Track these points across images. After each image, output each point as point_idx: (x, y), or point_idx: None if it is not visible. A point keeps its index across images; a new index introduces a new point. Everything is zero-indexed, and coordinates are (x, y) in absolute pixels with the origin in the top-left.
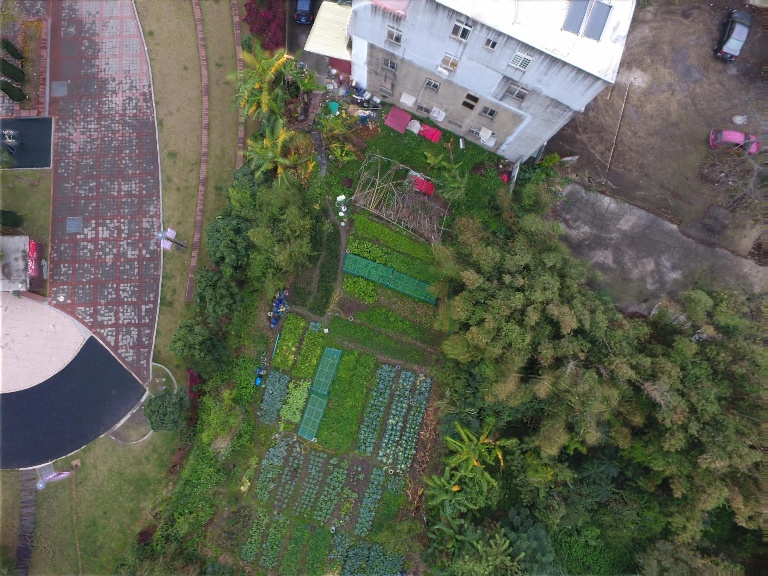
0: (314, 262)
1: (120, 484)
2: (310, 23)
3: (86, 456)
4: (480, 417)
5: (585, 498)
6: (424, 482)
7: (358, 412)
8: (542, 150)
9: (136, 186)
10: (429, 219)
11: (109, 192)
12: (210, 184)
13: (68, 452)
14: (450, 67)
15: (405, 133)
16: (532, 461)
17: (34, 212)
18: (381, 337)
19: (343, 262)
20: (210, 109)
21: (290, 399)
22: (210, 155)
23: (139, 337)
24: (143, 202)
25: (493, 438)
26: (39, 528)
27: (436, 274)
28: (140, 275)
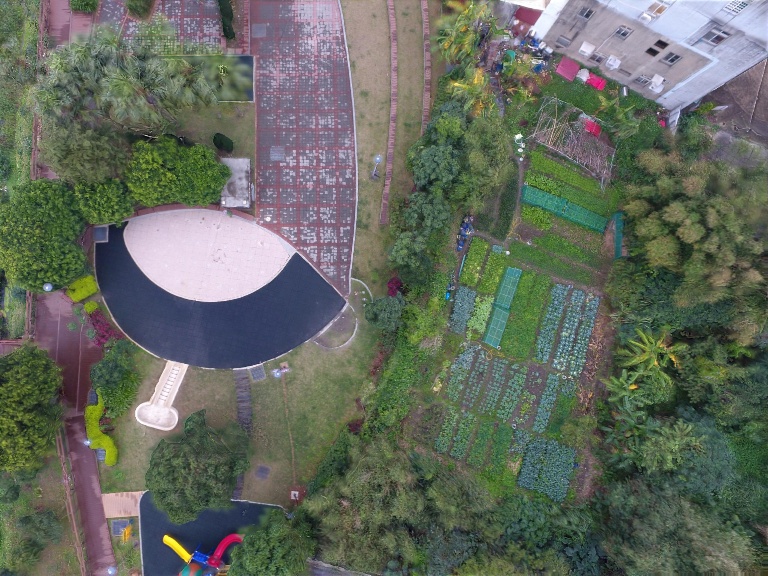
0: (496, 192)
1: (326, 383)
2: None
3: (293, 359)
4: (652, 327)
5: (751, 393)
6: (593, 387)
7: (536, 325)
8: (701, 98)
9: (332, 121)
10: (600, 156)
11: (308, 125)
12: (400, 121)
13: (277, 355)
14: (653, 14)
15: (574, 81)
16: (704, 362)
17: (241, 141)
18: (555, 260)
19: (522, 193)
20: (399, 53)
21: (478, 311)
22: (399, 95)
23: (339, 255)
24: (339, 135)
25: (667, 344)
26: (255, 420)
27: (604, 206)
28: (338, 200)
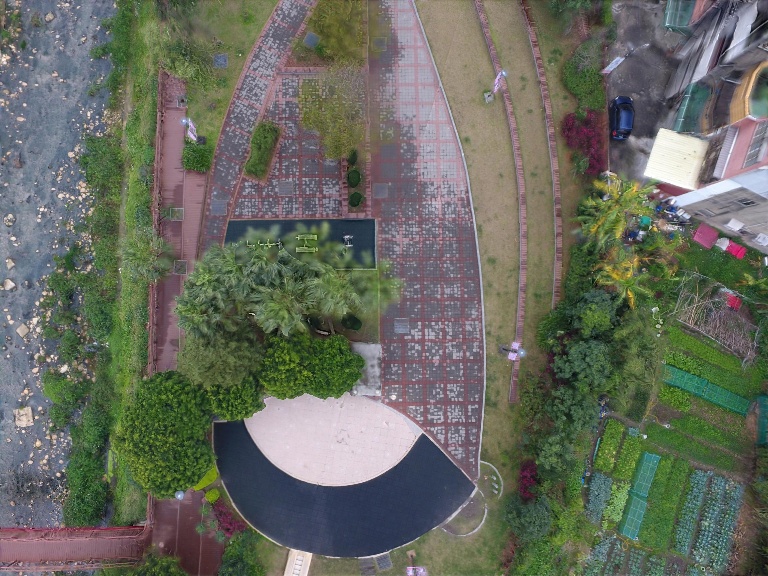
0: None
1: (456, 575)
2: (626, 139)
3: (421, 547)
4: None
5: None
6: None
7: (674, 513)
8: None
9: (458, 290)
10: (743, 335)
11: (433, 295)
12: (530, 291)
13: (403, 543)
14: None
15: (713, 249)
16: None
17: None
18: (694, 443)
19: (659, 372)
20: (528, 218)
21: (615, 501)
22: (529, 263)
23: (467, 436)
24: (465, 305)
25: None
26: None
27: (745, 386)
28: (465, 376)
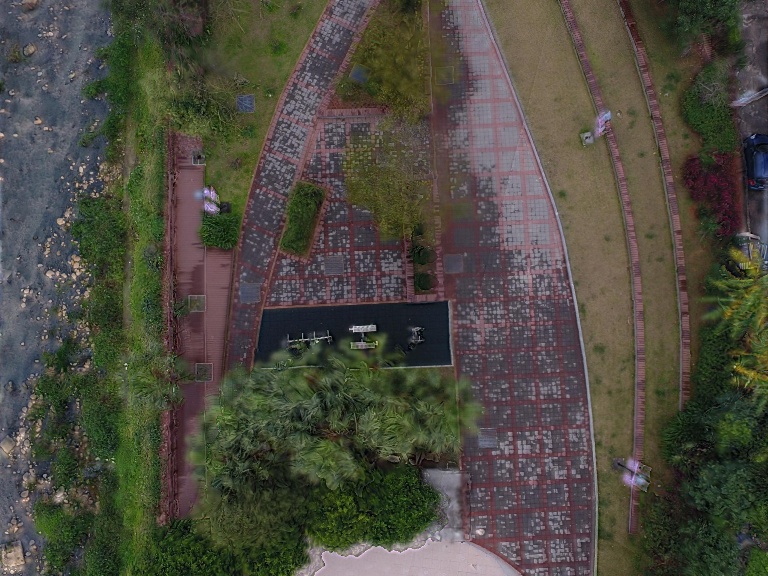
0: None
1: None
2: (767, 189)
3: None
4: None
5: None
6: None
7: None
8: None
9: (557, 388)
10: None
11: (526, 396)
12: (650, 388)
13: None
14: None
15: None
16: None
17: None
18: None
19: None
20: (644, 293)
21: None
22: (647, 351)
23: None
24: (568, 409)
25: None
26: None
27: None
28: (572, 501)
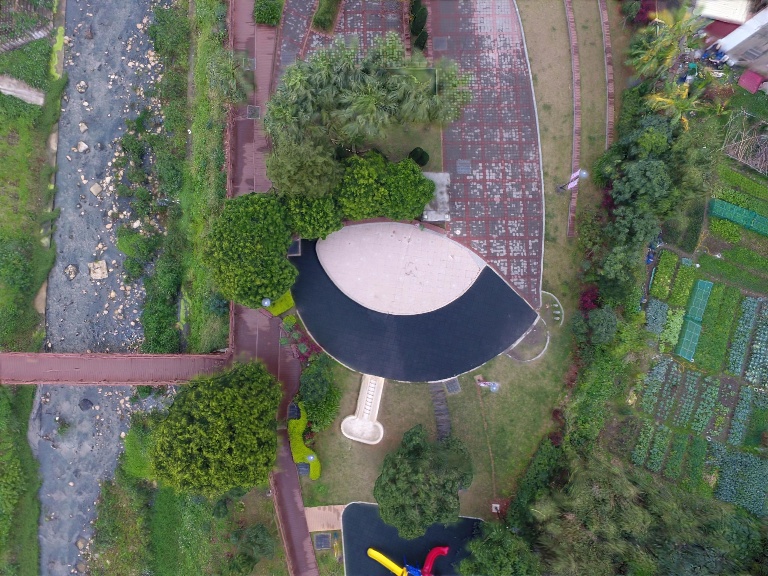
0: None
1: (522, 396)
2: None
3: (488, 372)
4: None
5: None
6: None
7: (727, 337)
8: None
9: (516, 134)
10: None
11: (492, 138)
12: (584, 134)
13: (471, 368)
14: None
15: (756, 94)
16: None
17: (428, 154)
18: (743, 273)
19: (709, 206)
20: (581, 66)
21: (671, 324)
22: (583, 108)
23: (529, 268)
24: (523, 148)
25: None
26: (454, 433)
27: None
28: (525, 213)
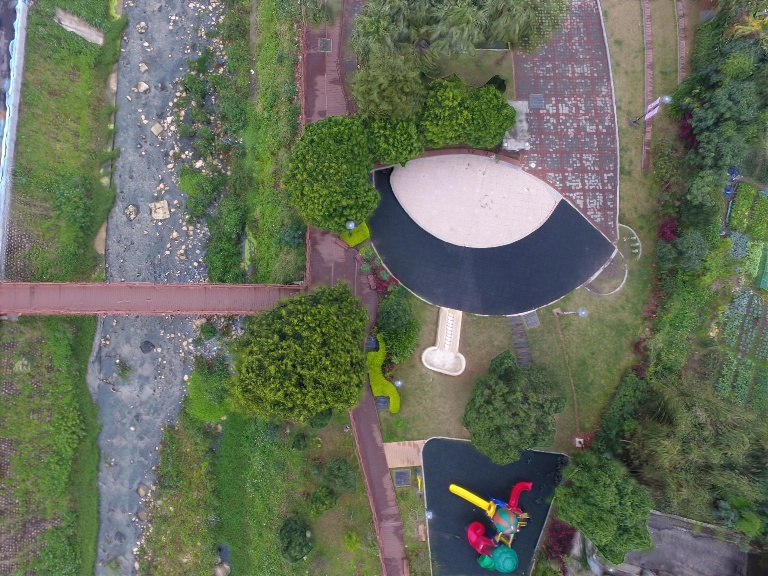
0: None
1: (603, 329)
2: None
3: (567, 305)
4: None
5: None
6: None
7: None
8: None
9: (588, 69)
10: None
11: (564, 73)
12: (656, 69)
13: (549, 301)
14: None
15: None
16: None
17: None
18: None
19: None
20: (650, 3)
21: (751, 256)
22: (654, 44)
23: (605, 201)
24: (595, 83)
25: None
26: (536, 366)
27: None
28: (600, 147)
